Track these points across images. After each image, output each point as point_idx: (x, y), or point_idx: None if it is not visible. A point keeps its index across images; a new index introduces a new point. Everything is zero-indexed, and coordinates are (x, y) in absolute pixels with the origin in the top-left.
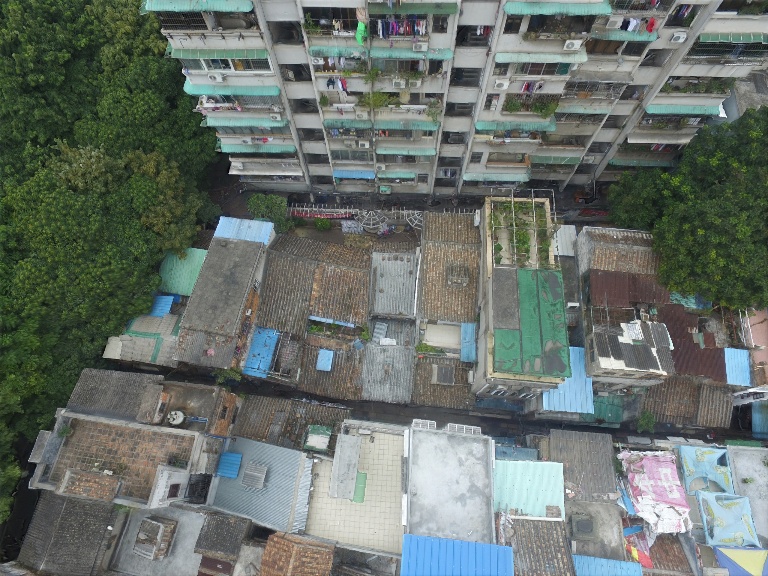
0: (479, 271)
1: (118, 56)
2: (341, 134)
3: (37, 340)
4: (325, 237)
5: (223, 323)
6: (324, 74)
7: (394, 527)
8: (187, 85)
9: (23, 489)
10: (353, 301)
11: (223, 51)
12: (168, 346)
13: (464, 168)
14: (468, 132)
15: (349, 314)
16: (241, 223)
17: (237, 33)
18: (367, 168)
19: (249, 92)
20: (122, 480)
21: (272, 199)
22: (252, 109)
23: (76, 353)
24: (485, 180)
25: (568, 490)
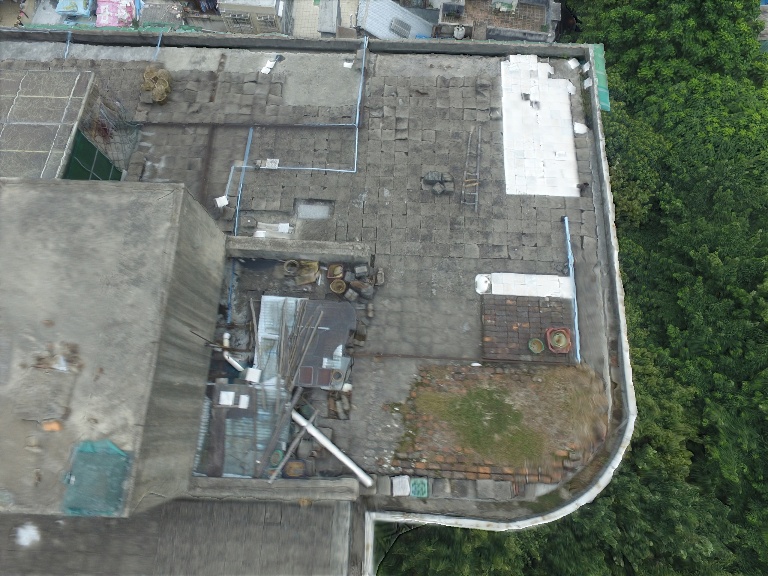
0: None
1: None
2: None
3: None
4: None
5: None
6: None
7: (301, 2)
8: None
9: (572, 23)
10: None
11: None
12: None
13: None
14: None
15: None
16: None
17: None
18: None
19: None
20: (492, 7)
21: None
22: None
23: None
24: None
25: (176, 9)
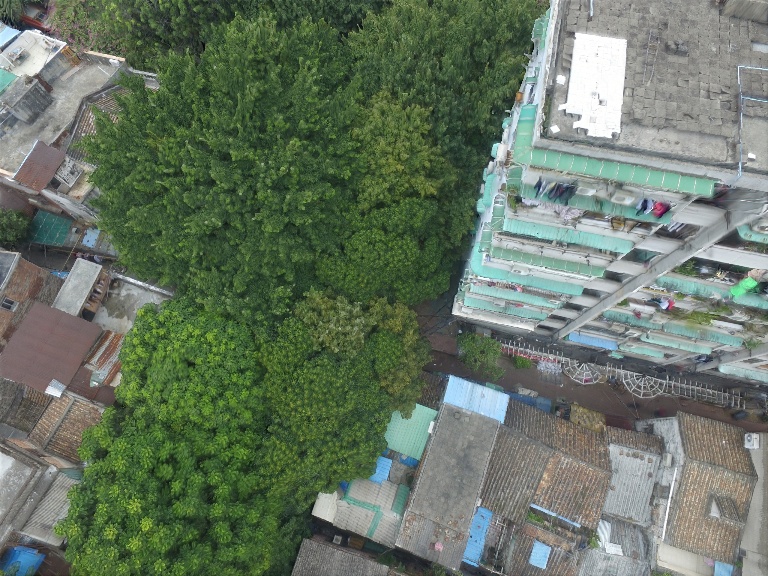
0: (748, 508)
1: (382, 195)
2: (613, 320)
3: (275, 520)
4: (517, 371)
5: (457, 518)
6: (650, 291)
7: None
8: (476, 264)
9: None
10: (586, 501)
11: (552, 260)
12: (387, 523)
13: (728, 363)
14: (762, 342)
15: (579, 514)
16: (473, 389)
17: (584, 253)
18: (611, 339)
19: (547, 286)
20: None
21: (490, 345)
22: (533, 292)
23: (294, 517)
24: (746, 377)
25: None
